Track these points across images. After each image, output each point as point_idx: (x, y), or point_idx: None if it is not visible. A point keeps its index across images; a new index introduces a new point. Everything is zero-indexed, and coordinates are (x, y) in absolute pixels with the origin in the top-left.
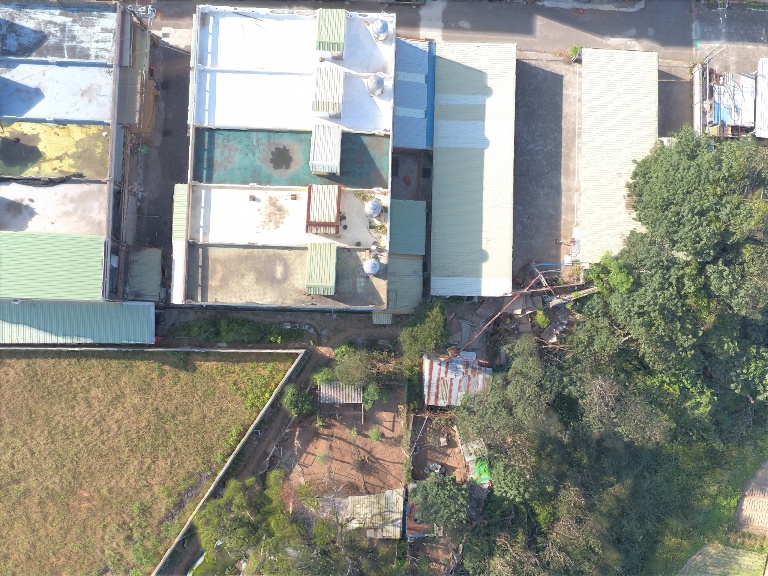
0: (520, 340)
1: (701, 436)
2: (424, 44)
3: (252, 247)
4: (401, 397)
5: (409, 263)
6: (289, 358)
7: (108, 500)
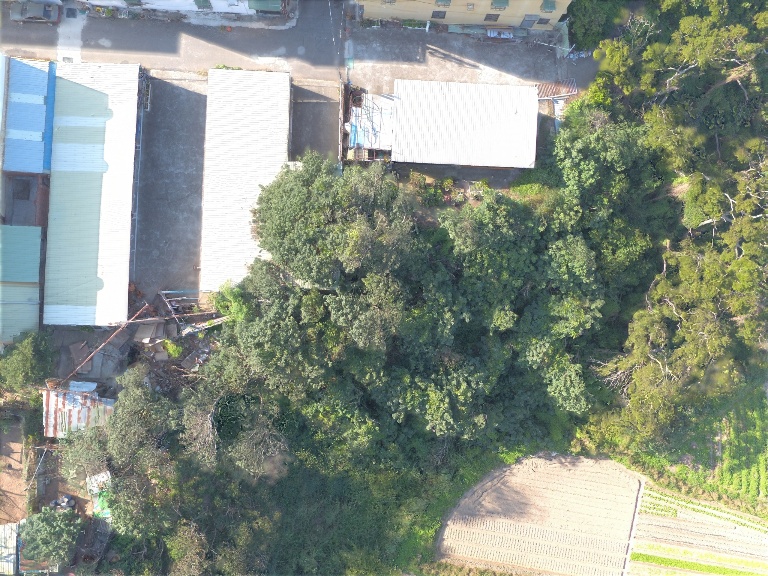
0: (127, 372)
1: (389, 465)
2: (44, 64)
3: None
4: None
5: (22, 291)
6: None
7: None
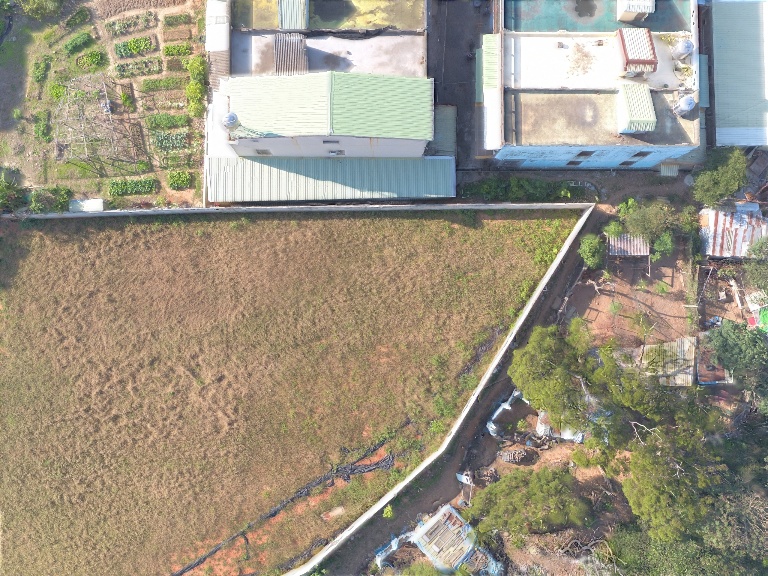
0: None
1: None
2: None
3: (563, 92)
4: (680, 252)
5: None
6: (574, 214)
7: (406, 354)
